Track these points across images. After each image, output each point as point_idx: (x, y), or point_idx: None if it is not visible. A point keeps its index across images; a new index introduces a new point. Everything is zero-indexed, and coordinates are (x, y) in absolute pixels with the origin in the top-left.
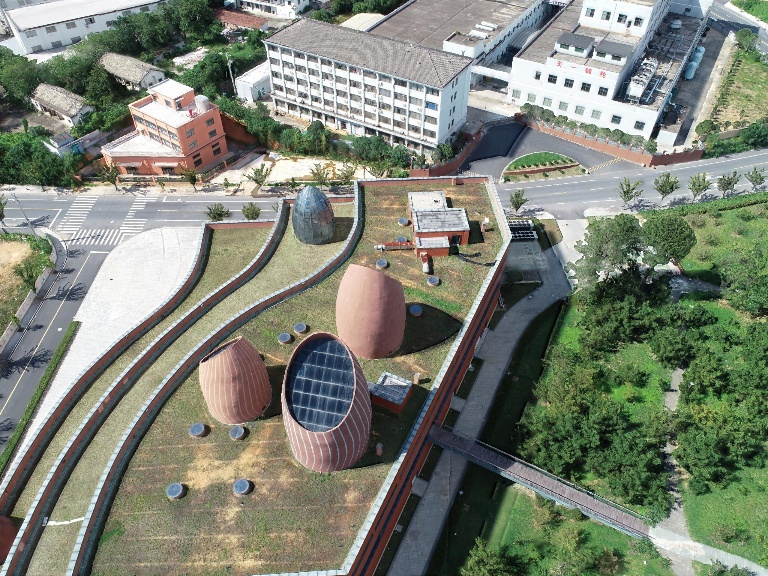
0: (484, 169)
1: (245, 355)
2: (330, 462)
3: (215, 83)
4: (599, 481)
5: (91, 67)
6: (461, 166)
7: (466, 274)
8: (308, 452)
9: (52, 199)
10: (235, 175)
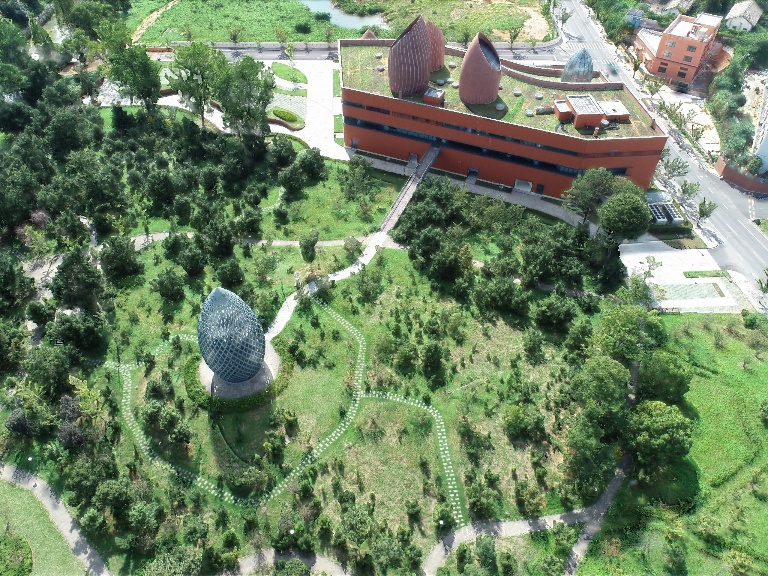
0: (765, 207)
1: (428, 30)
2: None
3: (766, 51)
4: None
5: (734, 3)
6: (759, 193)
7: (542, 126)
8: None
9: (595, 36)
10: (663, 89)
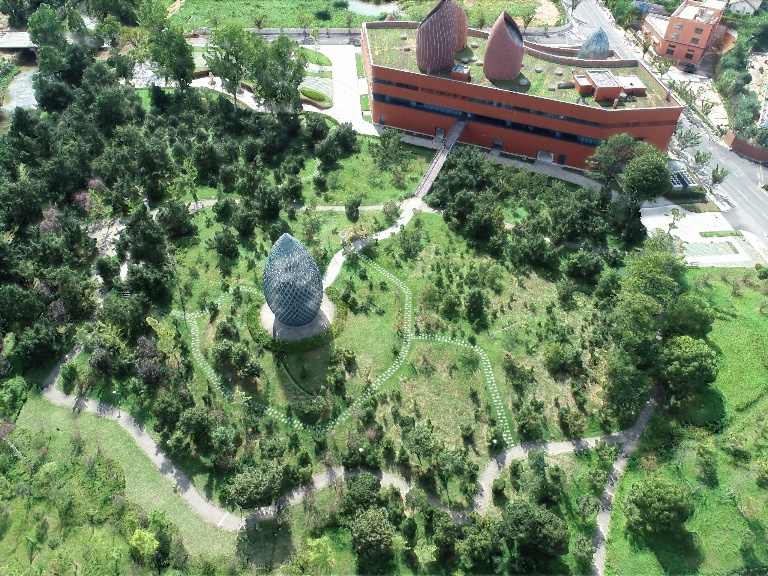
0: None
1: None
2: None
3: None
4: None
5: None
6: (767, 162)
7: (564, 99)
8: None
9: (604, 22)
10: None
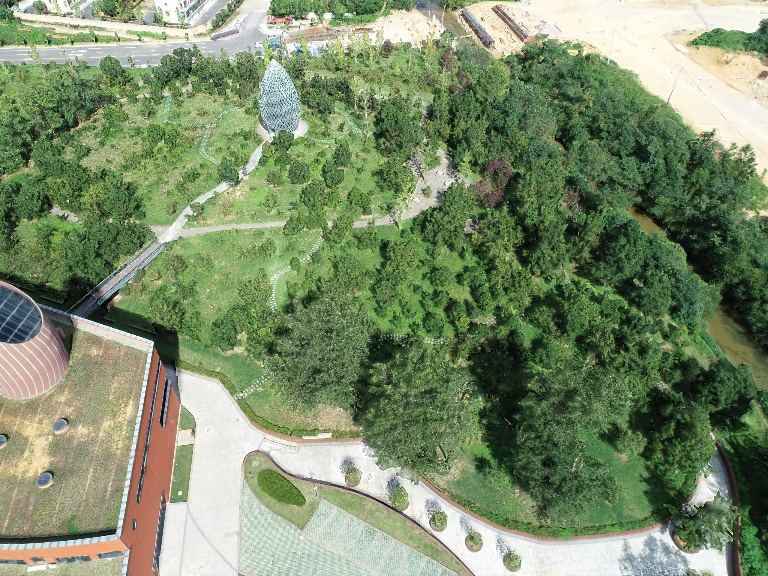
0: None
1: None
2: (62, 354)
3: None
4: (121, 261)
5: None
6: None
7: None
8: (50, 359)
9: None
10: None
